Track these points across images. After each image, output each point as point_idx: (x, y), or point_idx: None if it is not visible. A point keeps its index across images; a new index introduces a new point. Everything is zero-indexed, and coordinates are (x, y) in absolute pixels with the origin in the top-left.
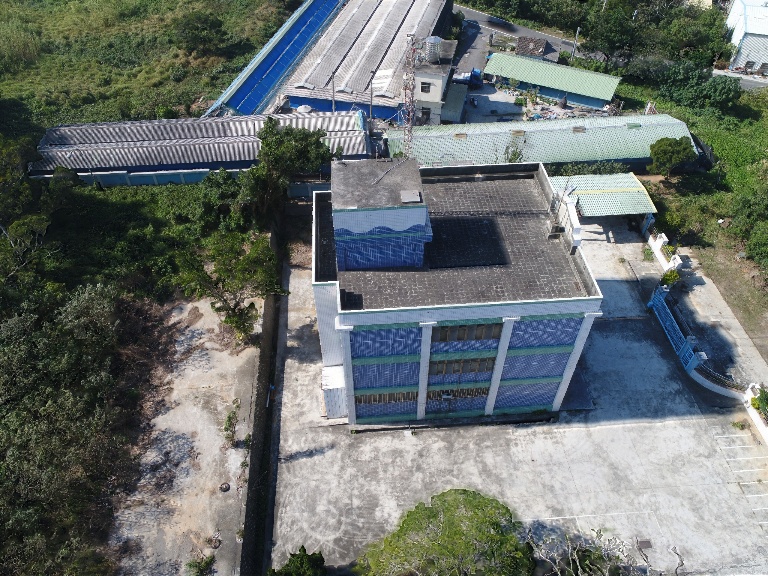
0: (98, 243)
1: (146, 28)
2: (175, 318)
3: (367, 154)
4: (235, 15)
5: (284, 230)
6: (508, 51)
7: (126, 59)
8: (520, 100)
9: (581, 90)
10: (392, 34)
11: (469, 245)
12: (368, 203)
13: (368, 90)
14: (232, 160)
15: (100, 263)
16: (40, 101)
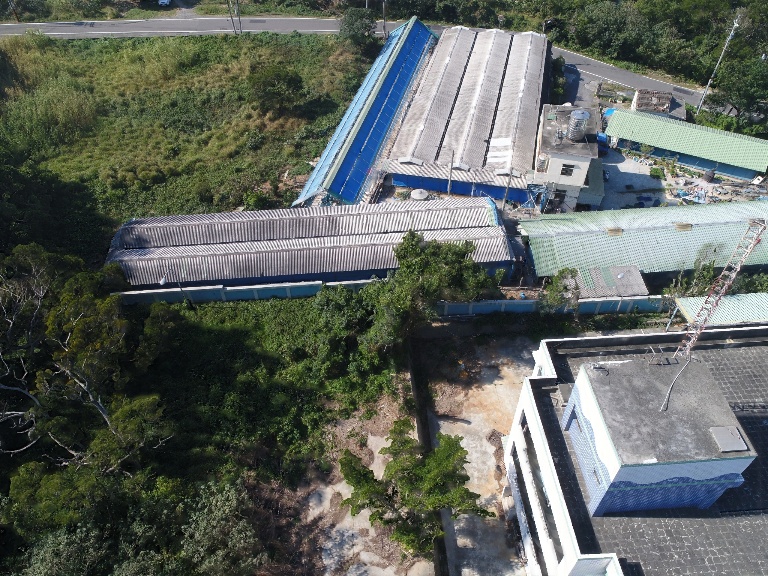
0: (203, 395)
1: (211, 82)
2: (314, 511)
3: (511, 260)
4: (308, 63)
5: (418, 361)
6: (619, 103)
7: (193, 122)
8: (656, 171)
9: (727, 158)
10: (496, 90)
11: (760, 467)
12: (670, 451)
13: (487, 166)
14: (349, 270)
15: (209, 426)
16: (105, 183)
